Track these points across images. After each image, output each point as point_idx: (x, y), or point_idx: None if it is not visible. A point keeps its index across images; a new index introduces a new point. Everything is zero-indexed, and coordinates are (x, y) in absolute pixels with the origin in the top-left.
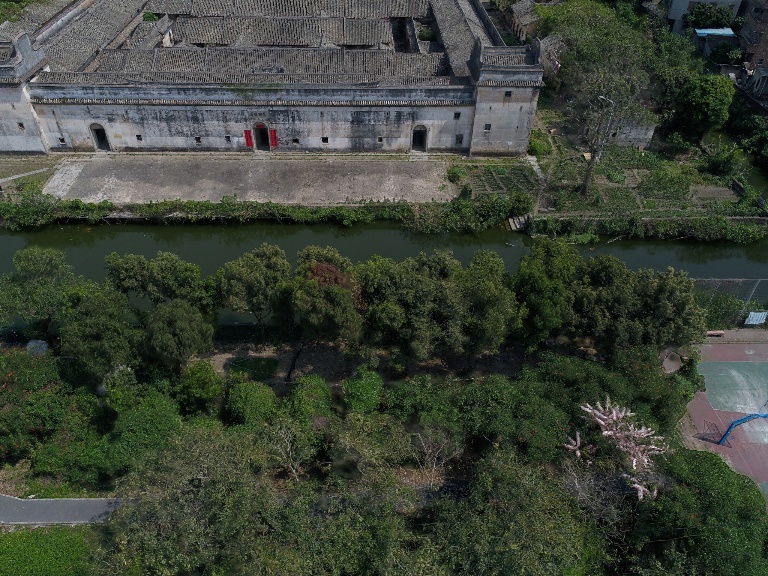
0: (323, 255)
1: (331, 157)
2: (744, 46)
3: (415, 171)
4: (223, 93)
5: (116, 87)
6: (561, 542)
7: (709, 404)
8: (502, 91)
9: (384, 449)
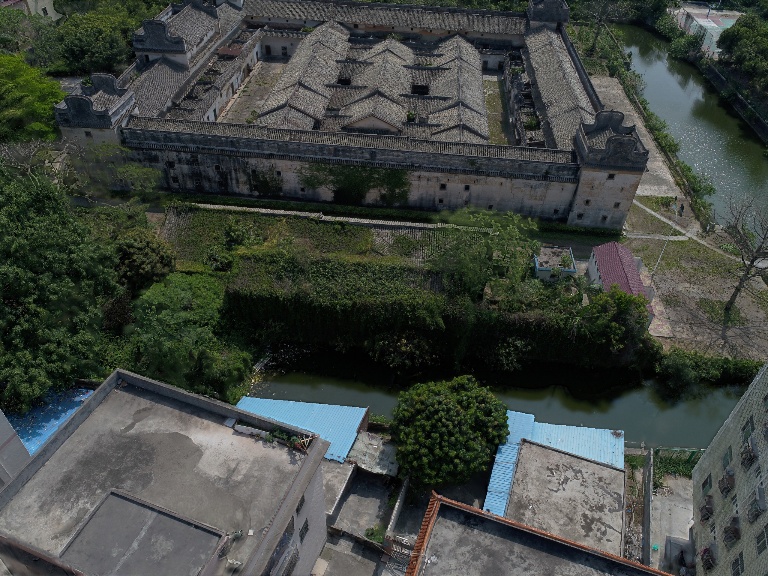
0: None
1: None
2: None
3: None
4: None
5: None
6: None
7: None
8: None
9: None
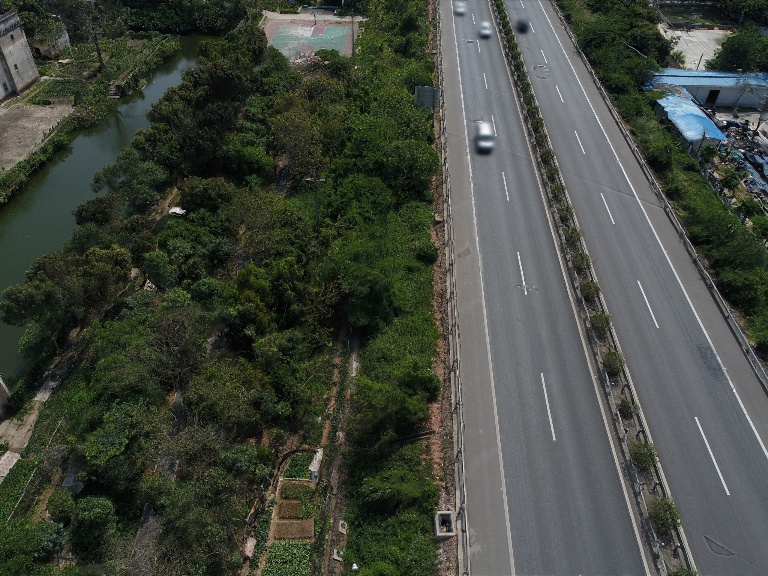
0: (179, 86)
1: None
2: None
3: (20, 115)
4: None
5: None
6: None
7: None
8: (8, 36)
9: None
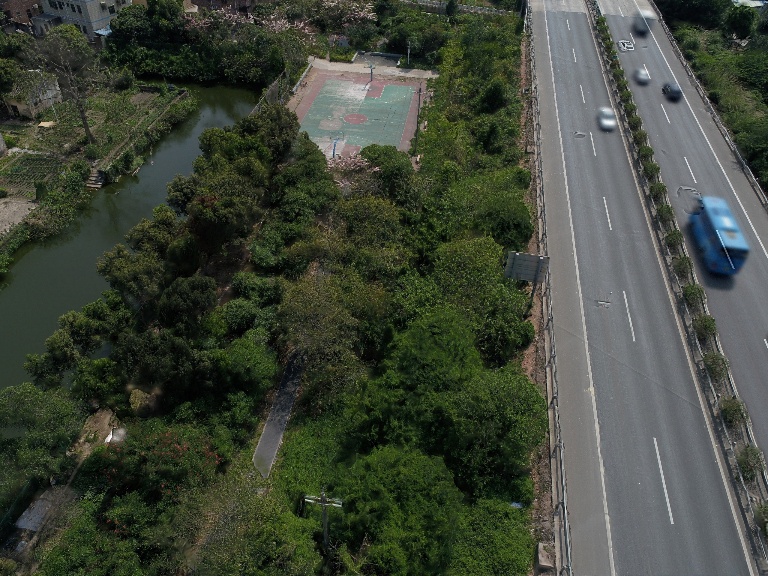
0: (151, 221)
1: None
2: None
3: None
4: None
5: None
6: None
7: None
8: None
9: None
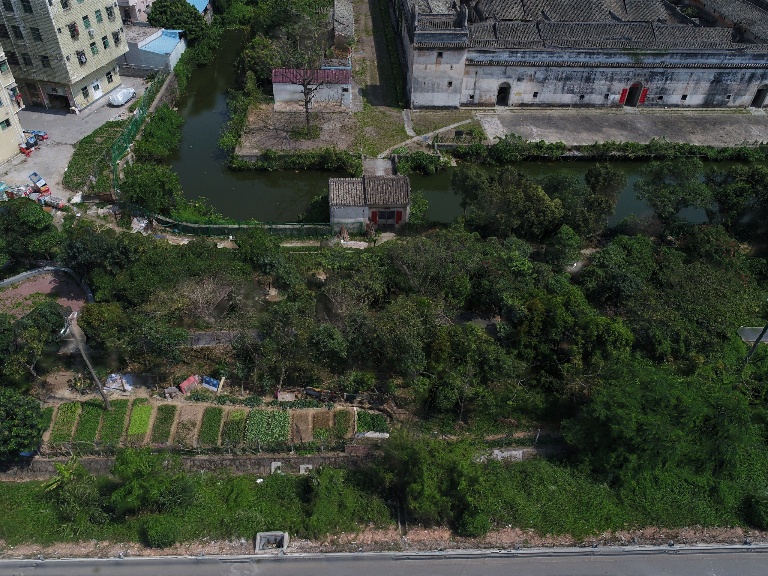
0: None
1: (687, 112)
2: None
3: (766, 122)
4: (620, 57)
5: (537, 51)
6: None
7: None
8: None
9: None
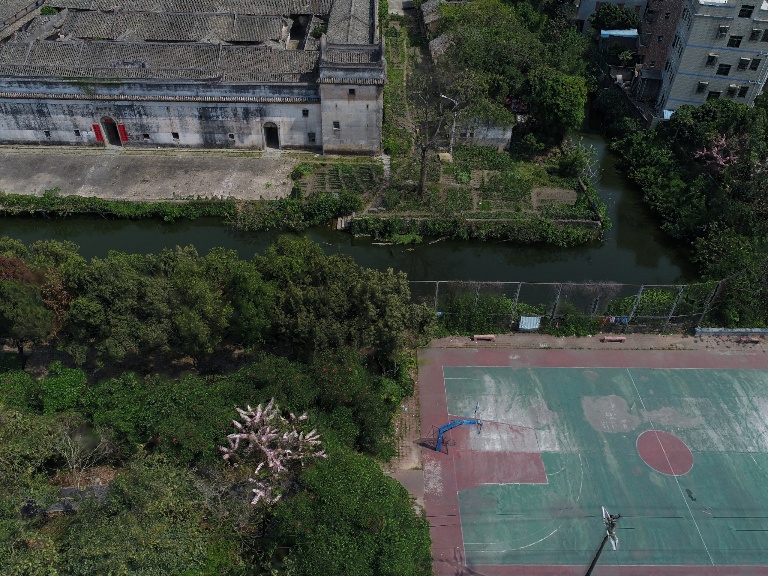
0: (50, 249)
1: (182, 153)
2: (637, 47)
3: (261, 168)
4: (64, 87)
5: None
6: (171, 546)
7: (446, 409)
8: (345, 89)
9: (26, 447)
